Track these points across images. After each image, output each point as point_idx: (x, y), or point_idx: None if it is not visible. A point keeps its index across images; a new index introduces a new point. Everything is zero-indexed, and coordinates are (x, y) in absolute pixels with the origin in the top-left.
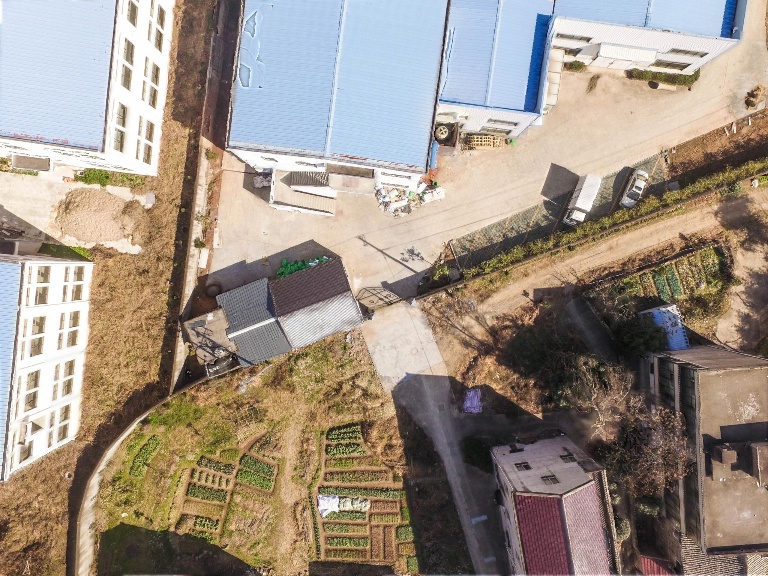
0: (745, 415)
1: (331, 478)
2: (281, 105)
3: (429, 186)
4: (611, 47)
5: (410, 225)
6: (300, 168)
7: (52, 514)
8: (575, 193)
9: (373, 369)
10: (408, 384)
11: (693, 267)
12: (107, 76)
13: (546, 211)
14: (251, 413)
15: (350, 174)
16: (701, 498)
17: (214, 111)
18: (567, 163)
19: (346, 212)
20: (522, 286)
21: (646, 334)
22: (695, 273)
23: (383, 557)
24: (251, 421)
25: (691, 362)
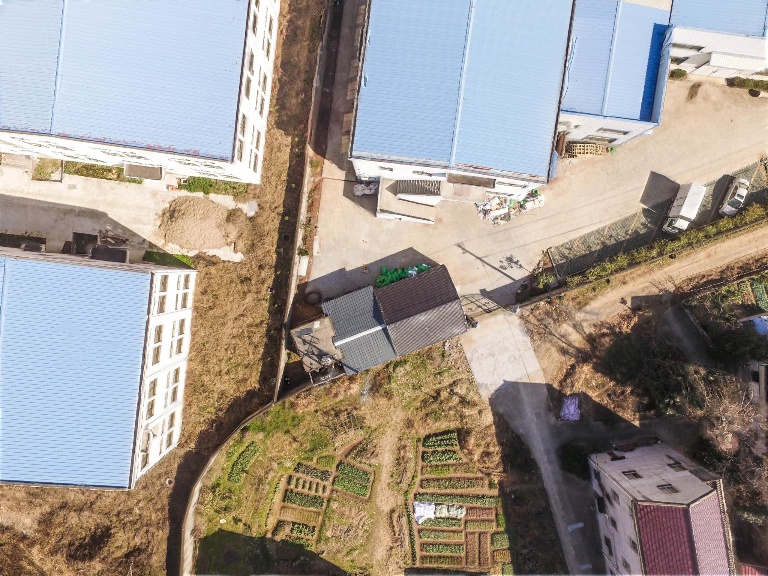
0: None
1: (427, 485)
2: (415, 116)
3: (529, 194)
4: (722, 56)
5: (509, 233)
6: (410, 177)
7: (152, 520)
8: (677, 201)
9: (471, 376)
10: (505, 391)
11: None
12: (238, 87)
13: (645, 219)
14: (350, 420)
15: (472, 184)
16: None
17: (316, 119)
18: (666, 171)
19: (445, 220)
20: (620, 294)
21: (751, 342)
22: None
23: (478, 564)
24: (350, 428)
25: None
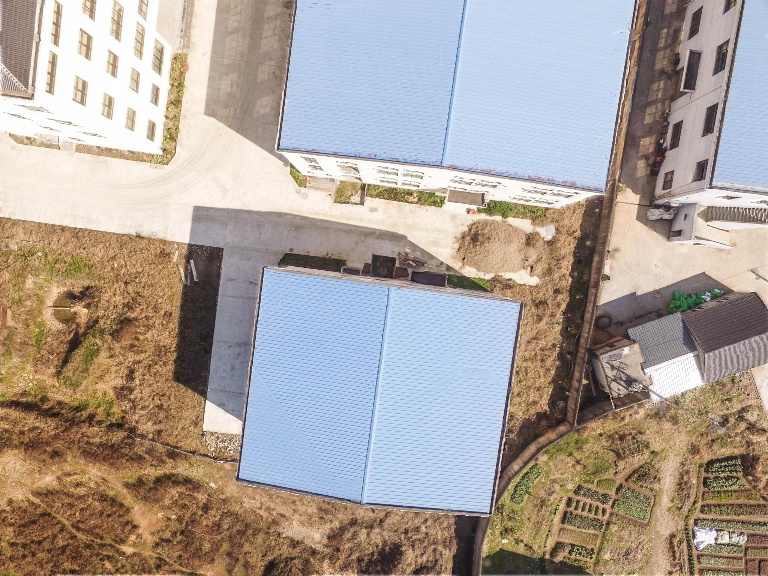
0: None
1: (709, 511)
2: None
3: None
4: None
5: None
6: (734, 204)
7: (439, 539)
8: None
9: (760, 403)
10: None
11: None
12: (615, 118)
13: None
14: (639, 445)
15: None
16: None
17: None
18: None
19: (739, 245)
20: None
21: None
22: None
23: None
24: (639, 453)
25: None
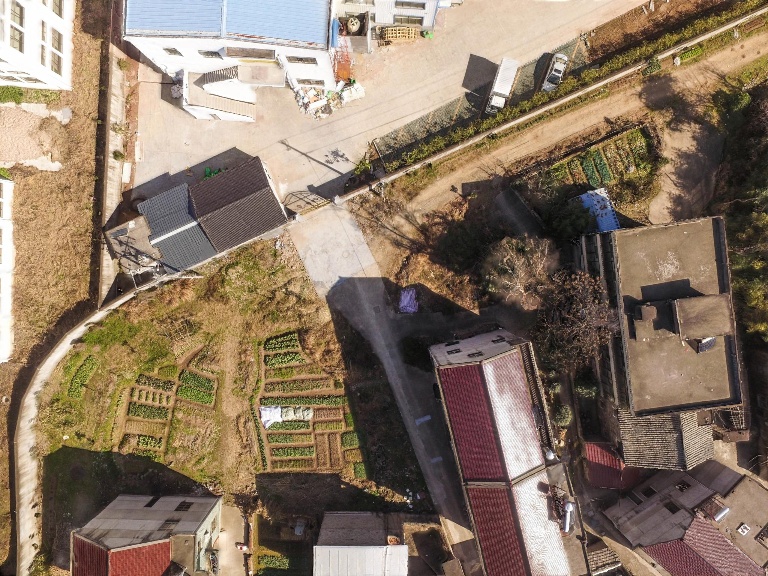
0: (665, 273)
1: (271, 388)
2: None
3: (348, 84)
4: None
5: (332, 126)
6: (209, 65)
7: None
8: (494, 80)
9: (305, 275)
10: (342, 288)
11: (621, 151)
12: None
13: (468, 103)
14: (185, 326)
15: (251, 56)
16: (626, 360)
17: None
18: (486, 53)
19: (267, 117)
20: (450, 181)
21: (572, 215)
22: (623, 157)
23: (330, 465)
24: (185, 334)
25: (612, 230)
